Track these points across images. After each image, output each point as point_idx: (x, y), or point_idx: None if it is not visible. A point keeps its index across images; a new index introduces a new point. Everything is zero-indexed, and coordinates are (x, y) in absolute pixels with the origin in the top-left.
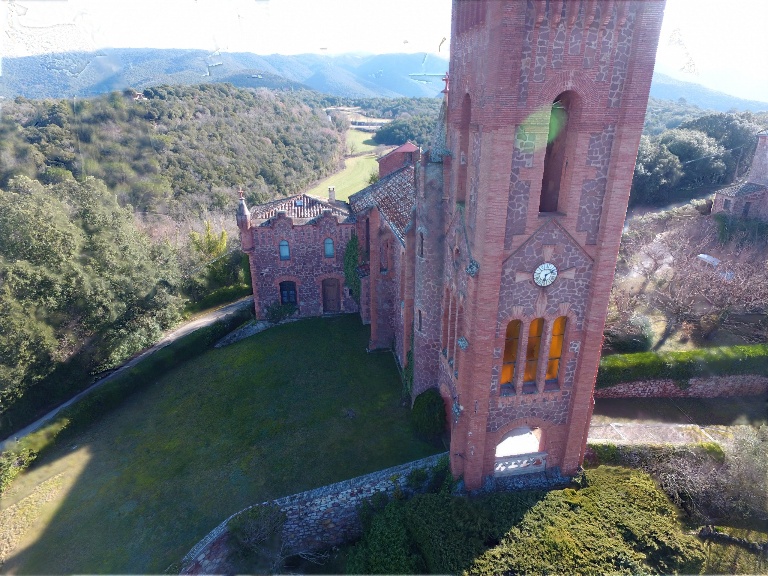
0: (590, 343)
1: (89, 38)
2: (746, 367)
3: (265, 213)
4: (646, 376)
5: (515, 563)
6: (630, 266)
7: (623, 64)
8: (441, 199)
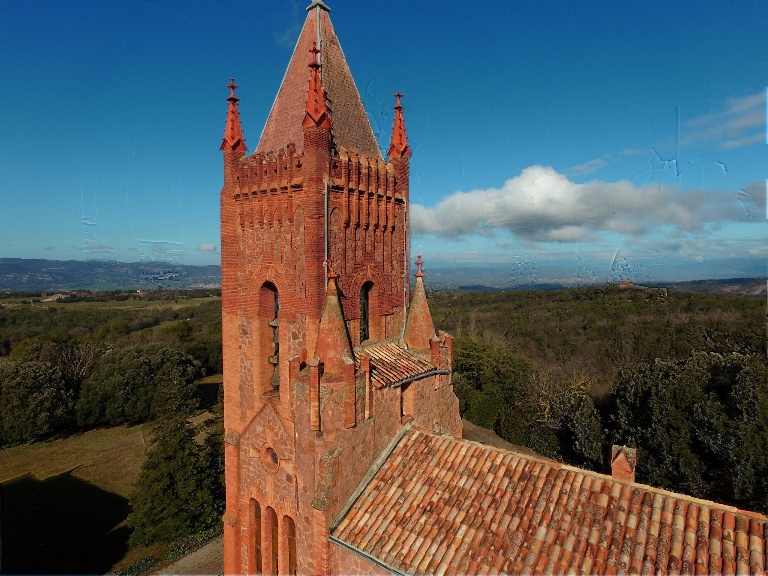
0: None
1: None
2: None
3: None
4: None
5: None
6: None
7: None
8: None
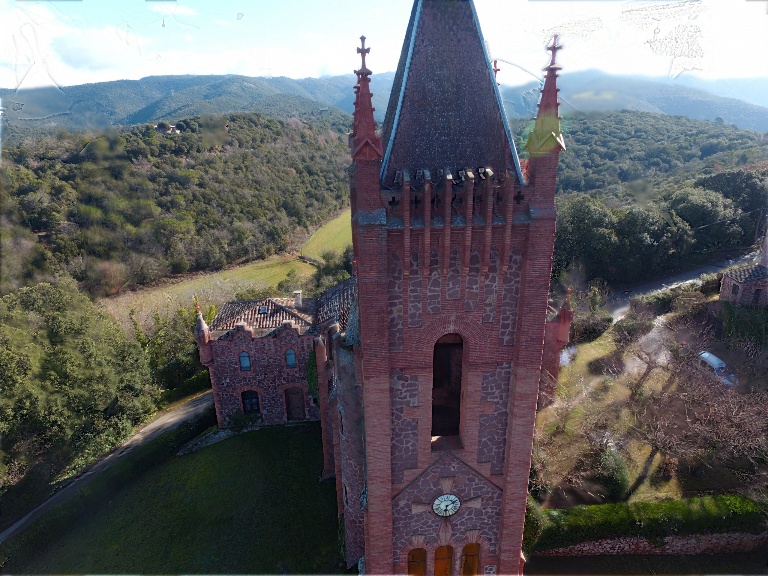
0: (506, 571)
1: (87, 122)
2: (732, 523)
3: (226, 323)
4: (615, 532)
5: None
6: (615, 377)
7: (513, 304)
8: (355, 384)
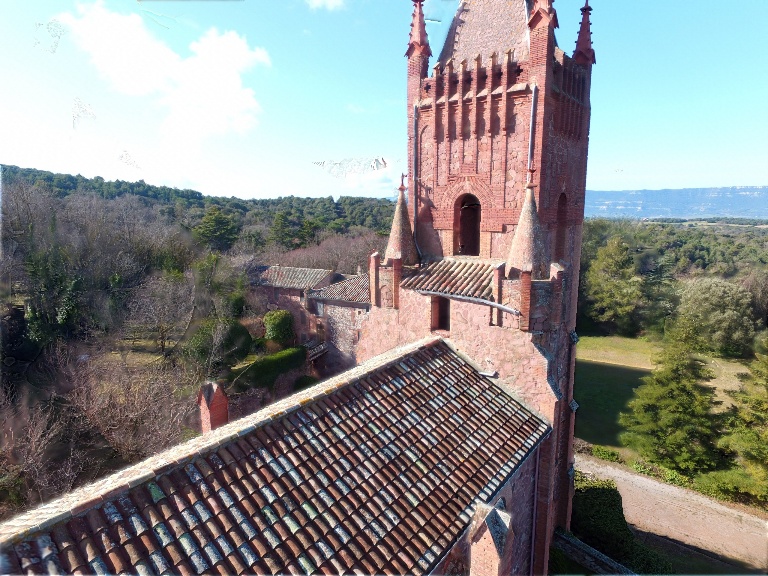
0: None
1: None
2: None
3: None
4: None
5: (577, 476)
6: None
7: None
8: None
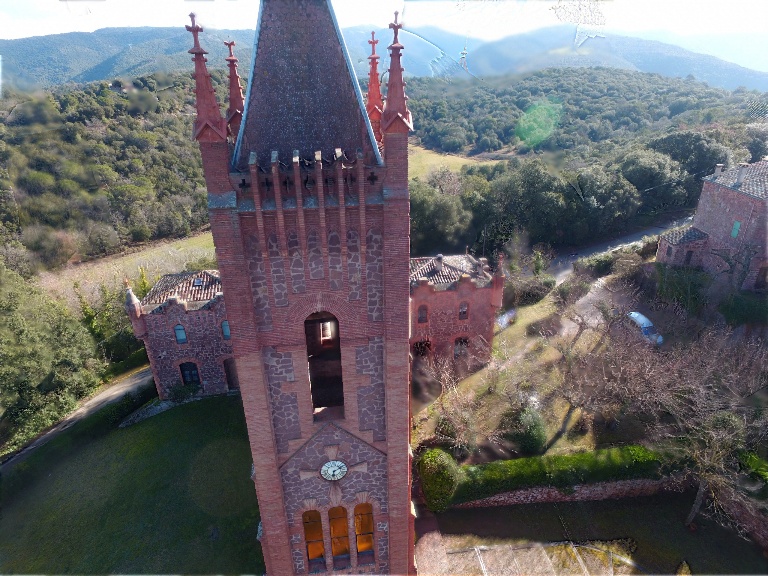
0: (396, 526)
1: (10, 84)
2: (635, 471)
3: (160, 296)
4: (528, 484)
5: None
6: (544, 339)
7: (378, 282)
8: None
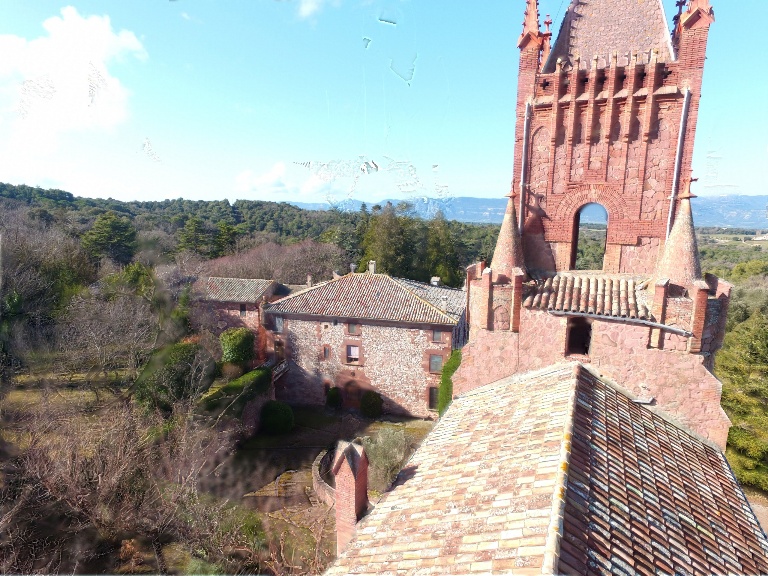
0: None
1: None
2: None
3: None
4: None
5: None
6: None
7: None
8: None
